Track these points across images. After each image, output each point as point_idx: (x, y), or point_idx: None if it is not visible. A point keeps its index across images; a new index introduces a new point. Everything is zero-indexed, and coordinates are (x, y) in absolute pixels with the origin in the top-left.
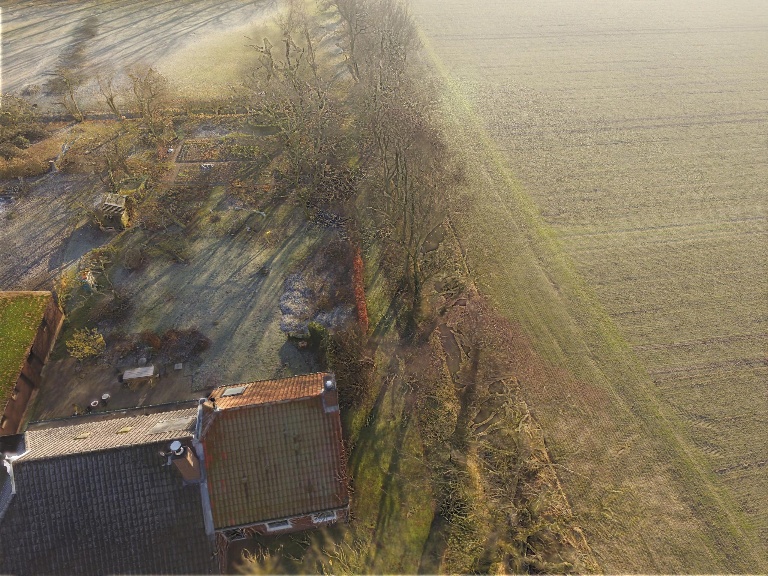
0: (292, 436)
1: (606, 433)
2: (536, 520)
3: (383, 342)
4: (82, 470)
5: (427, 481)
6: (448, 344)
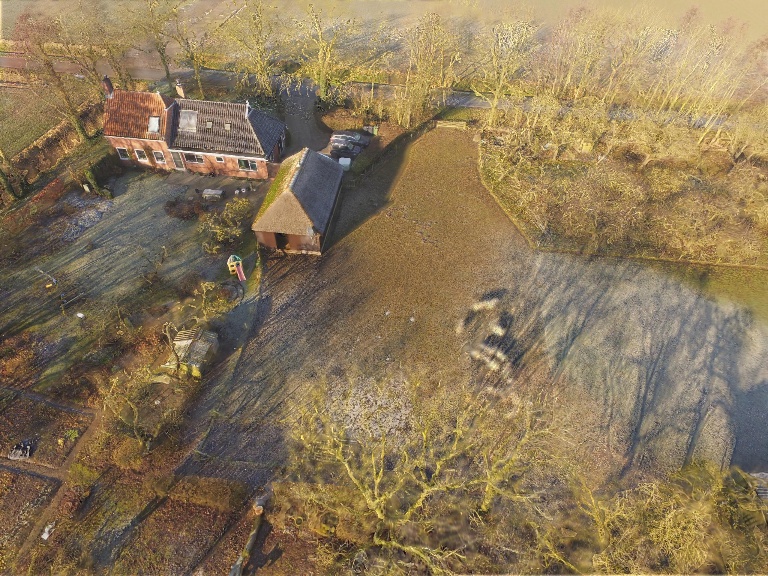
0: None
1: (4, 133)
2: None
3: None
4: None
5: None
6: None
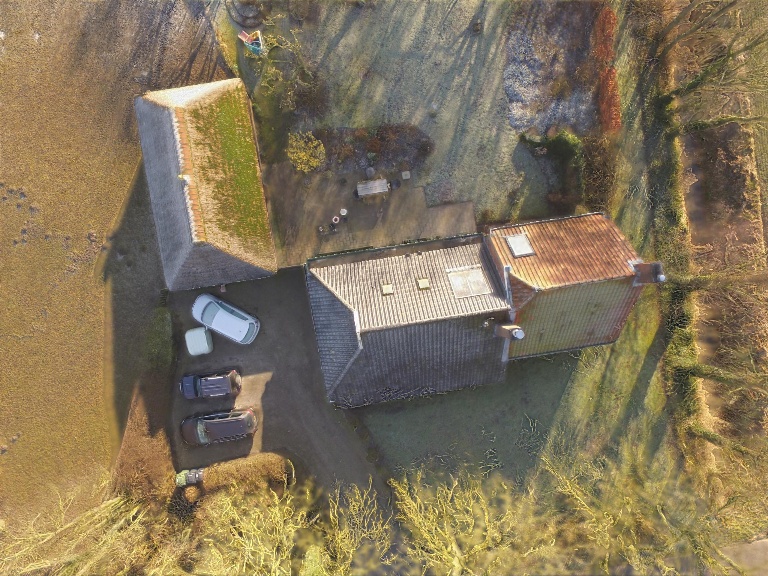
0: (594, 304)
1: None
2: (738, 328)
3: (625, 143)
4: (415, 333)
5: (656, 299)
6: (685, 136)
